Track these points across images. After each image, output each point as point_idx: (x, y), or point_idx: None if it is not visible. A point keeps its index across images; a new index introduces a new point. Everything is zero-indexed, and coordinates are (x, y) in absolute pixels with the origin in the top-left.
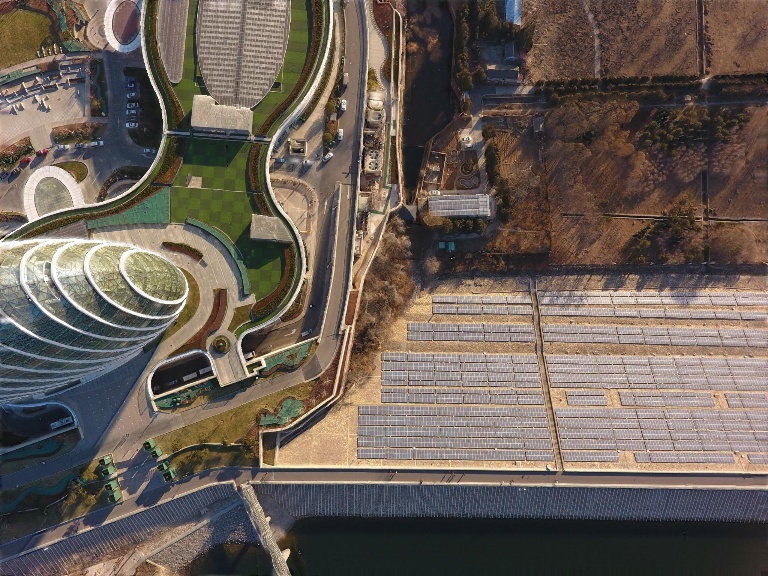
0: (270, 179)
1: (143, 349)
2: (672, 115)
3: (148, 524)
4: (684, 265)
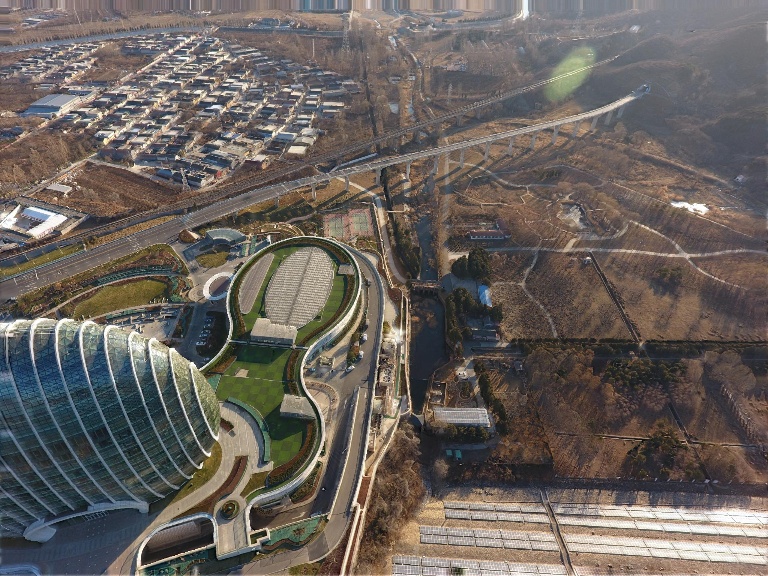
0: None
1: (149, 511)
2: (624, 362)
3: None
4: (689, 483)
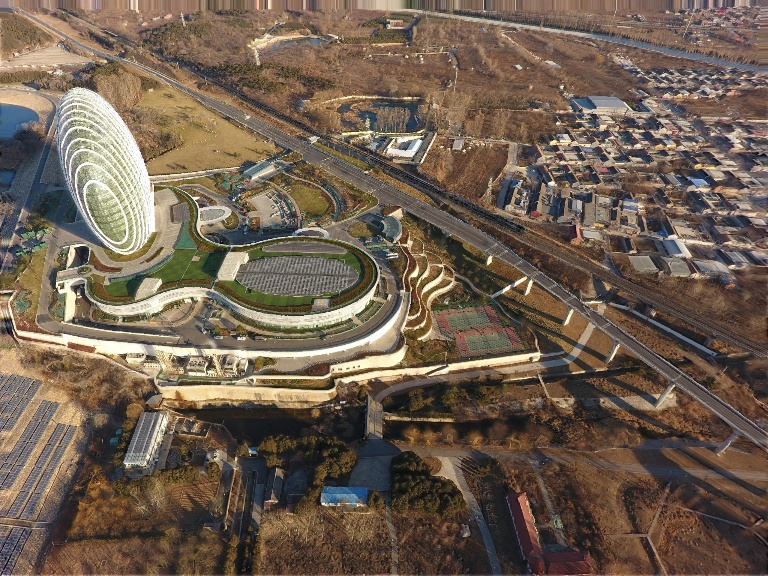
0: (198, 301)
1: None
2: None
3: (1, 251)
4: None
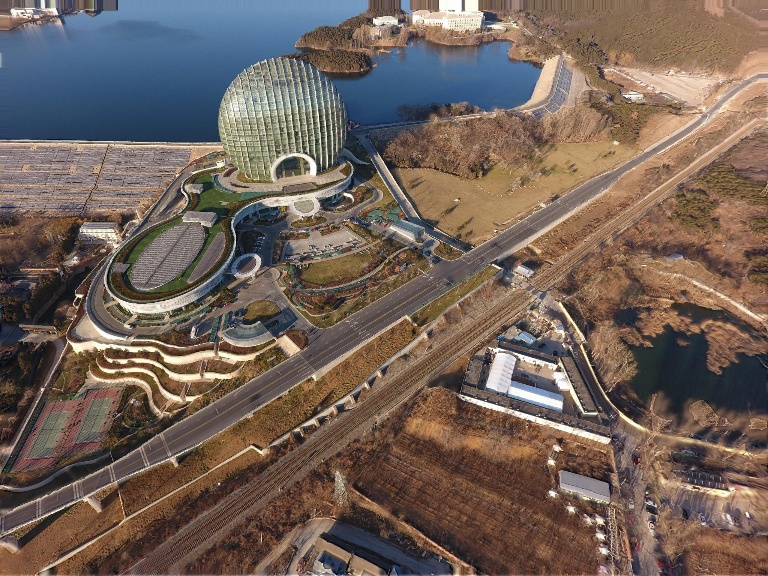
0: None
1: None
2: None
3: None
4: None
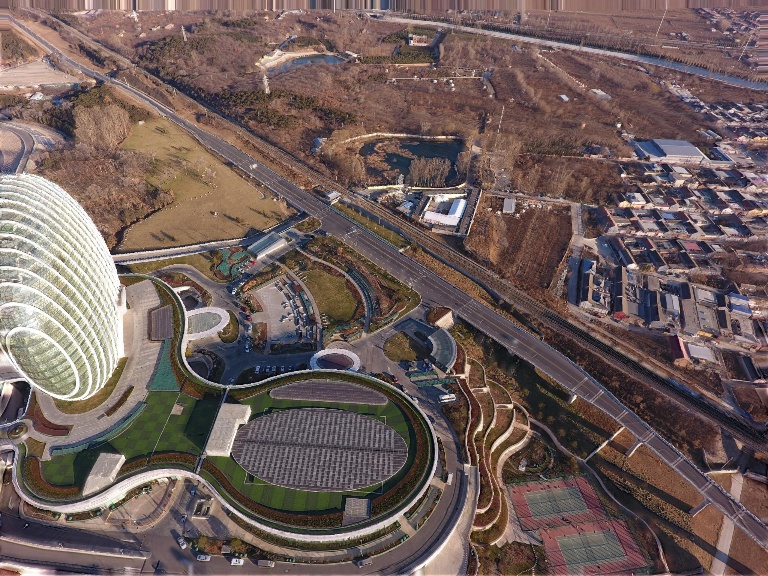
0: (177, 480)
1: None
2: None
3: None
4: None
